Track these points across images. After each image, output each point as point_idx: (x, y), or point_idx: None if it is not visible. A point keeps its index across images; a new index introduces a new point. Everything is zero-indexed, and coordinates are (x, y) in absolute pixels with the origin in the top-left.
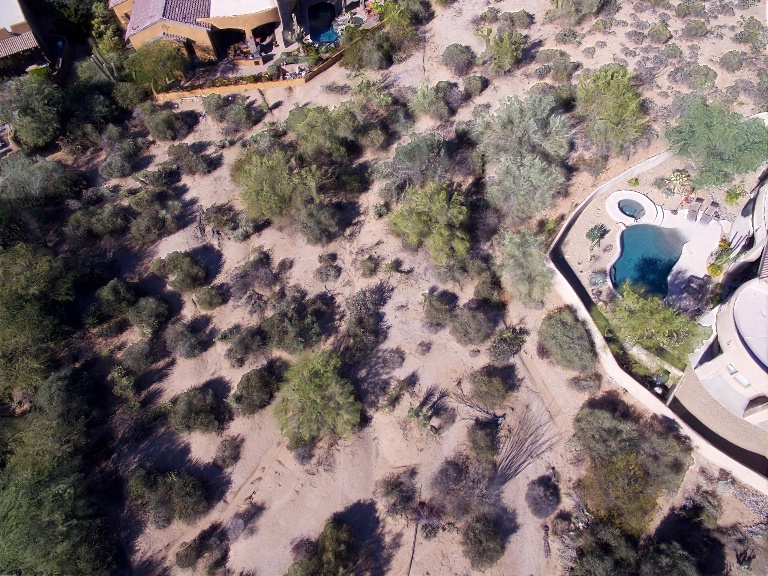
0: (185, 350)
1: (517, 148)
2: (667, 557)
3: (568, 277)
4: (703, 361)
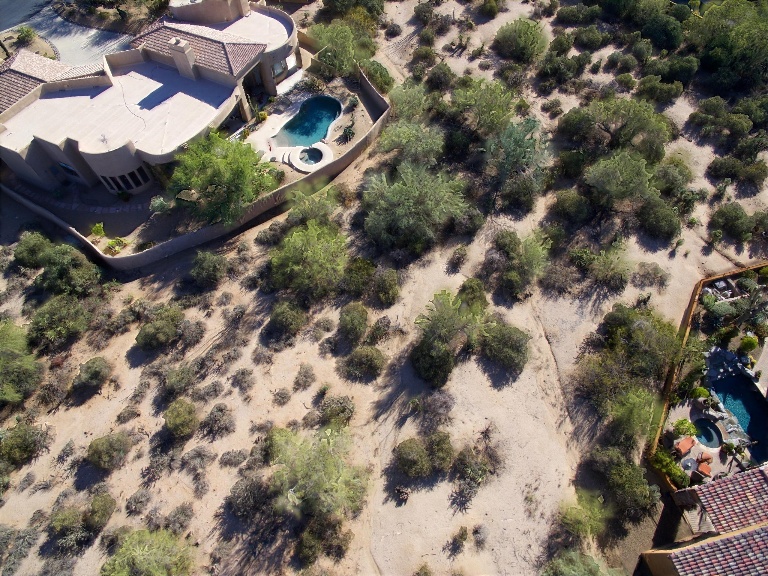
0: (616, 51)
1: None
2: (345, 4)
3: (372, 110)
4: (295, 71)
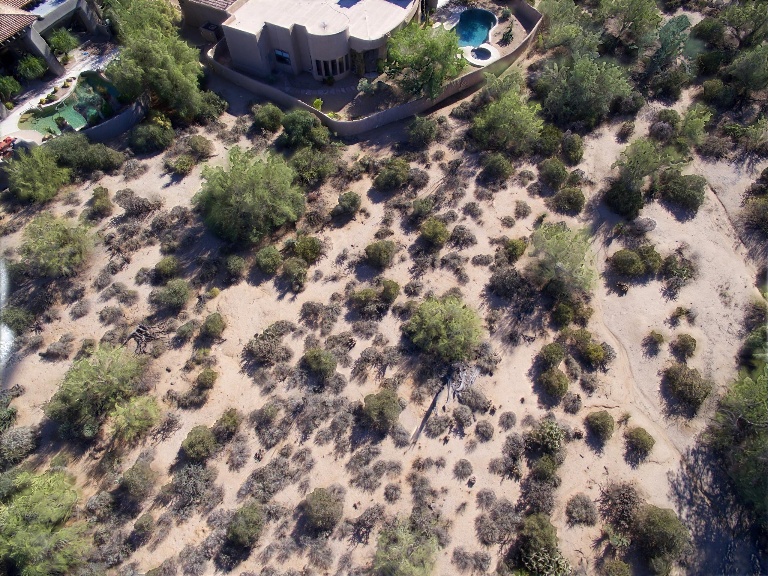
0: None
1: None
2: None
3: None
4: None
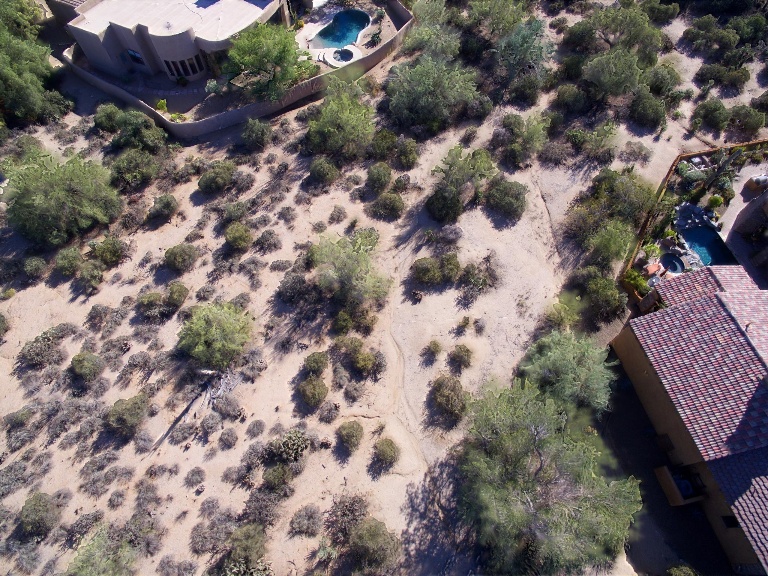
0: None
1: None
2: None
3: (397, 22)
4: None
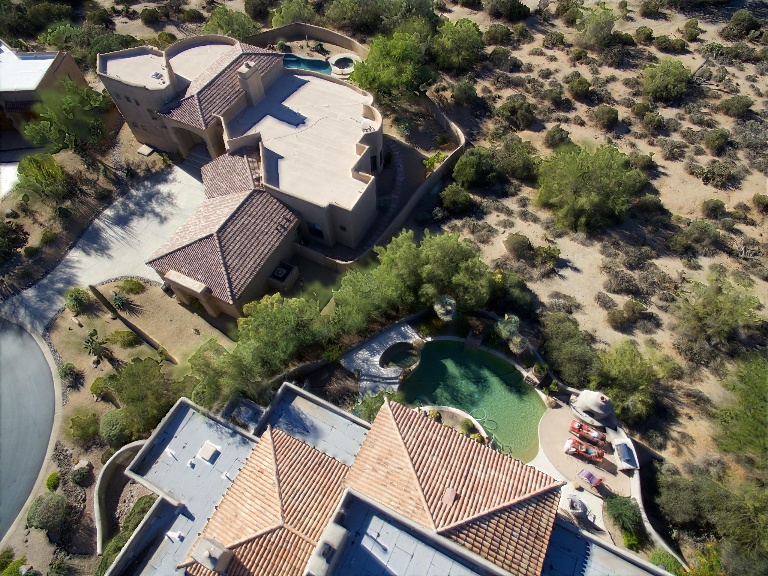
0: None
1: (382, 1)
2: None
3: None
4: None
